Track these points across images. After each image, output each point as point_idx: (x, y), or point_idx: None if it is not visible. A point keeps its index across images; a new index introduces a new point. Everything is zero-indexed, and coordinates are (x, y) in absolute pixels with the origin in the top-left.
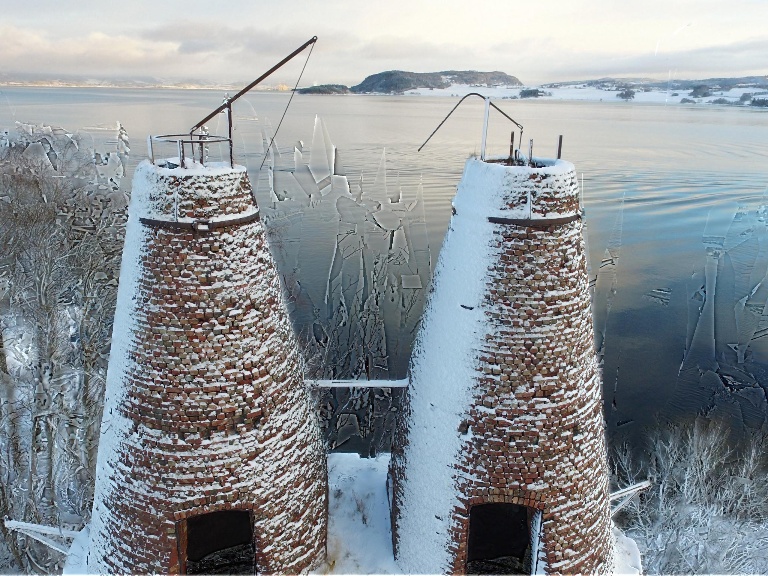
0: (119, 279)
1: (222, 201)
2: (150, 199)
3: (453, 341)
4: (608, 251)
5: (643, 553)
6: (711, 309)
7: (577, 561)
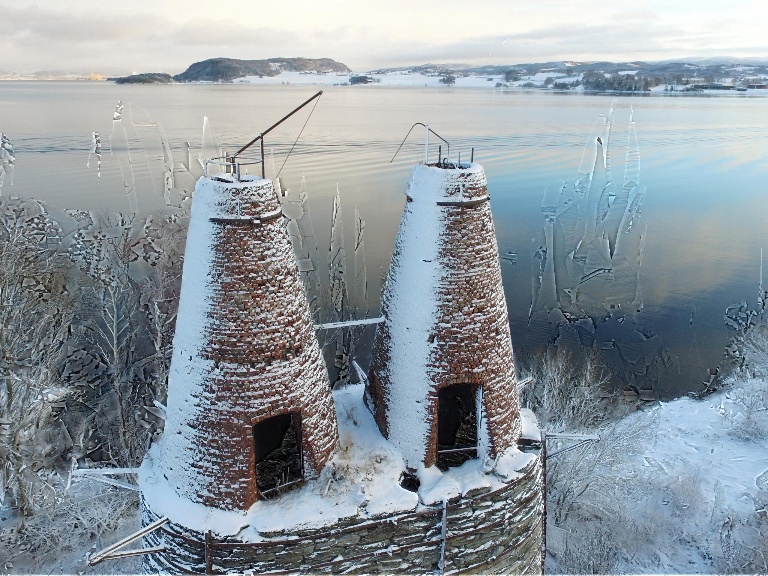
0: (188, 263)
1: (266, 203)
2: (218, 205)
3: (420, 284)
4: None
5: None
6: (552, 262)
7: (504, 416)
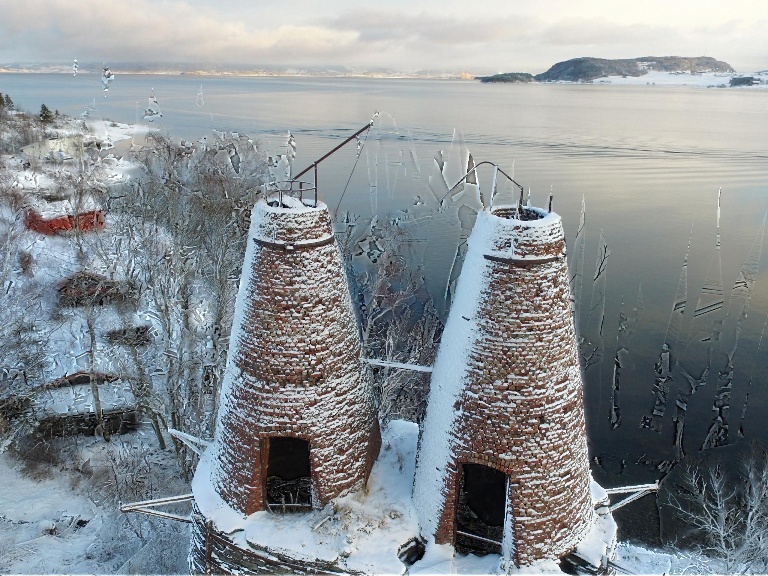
0: None
1: (304, 230)
2: (260, 227)
3: (455, 342)
4: (742, 273)
5: (722, 575)
6: None
7: (539, 520)
